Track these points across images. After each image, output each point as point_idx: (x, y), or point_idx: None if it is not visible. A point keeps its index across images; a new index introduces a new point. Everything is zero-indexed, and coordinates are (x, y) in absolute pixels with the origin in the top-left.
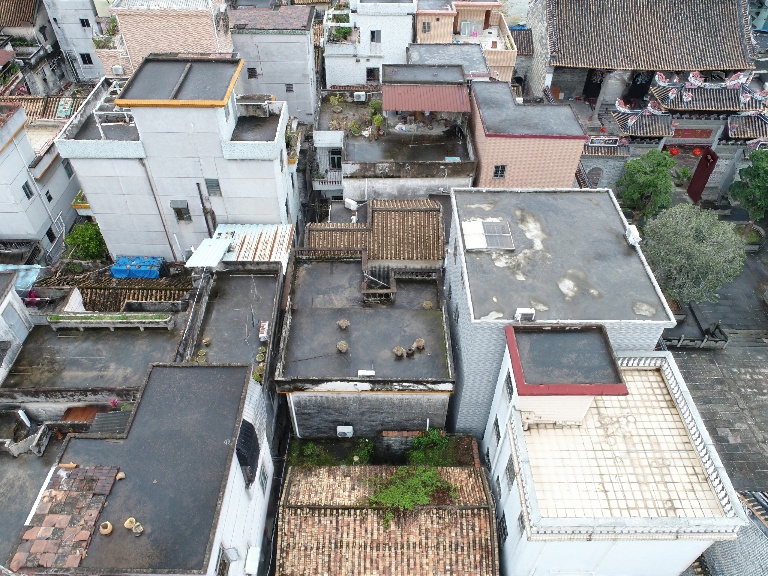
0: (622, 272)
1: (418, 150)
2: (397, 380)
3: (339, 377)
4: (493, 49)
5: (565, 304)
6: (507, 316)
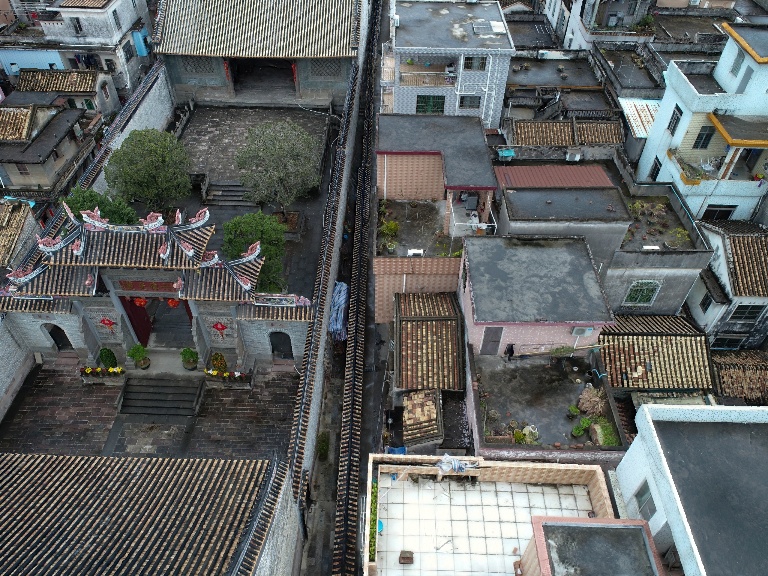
0: (410, 15)
1: None
2: (526, 49)
3: (557, 49)
4: (410, 550)
5: (448, 7)
6: (480, 4)
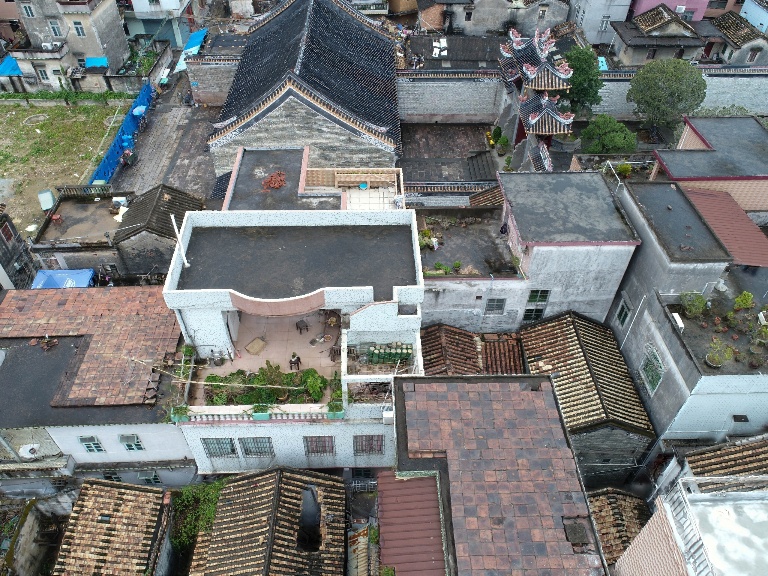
0: None
1: (767, 269)
2: None
3: None
4: None
5: None
6: None
